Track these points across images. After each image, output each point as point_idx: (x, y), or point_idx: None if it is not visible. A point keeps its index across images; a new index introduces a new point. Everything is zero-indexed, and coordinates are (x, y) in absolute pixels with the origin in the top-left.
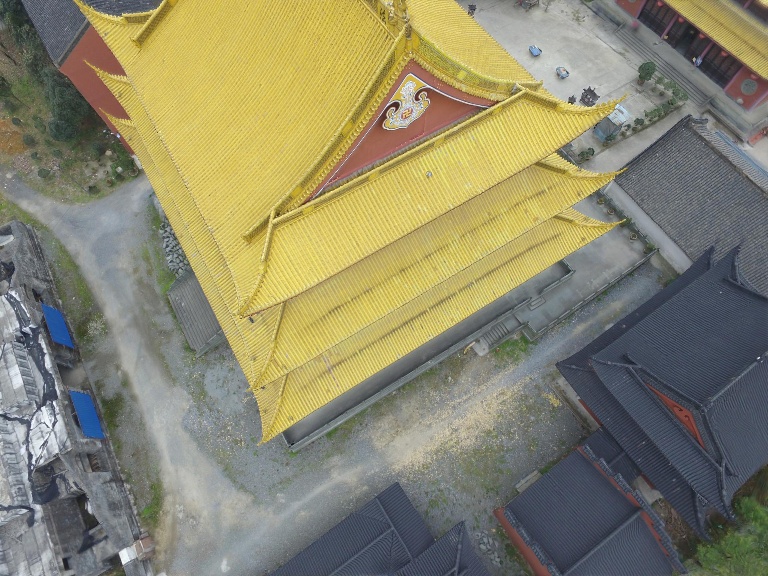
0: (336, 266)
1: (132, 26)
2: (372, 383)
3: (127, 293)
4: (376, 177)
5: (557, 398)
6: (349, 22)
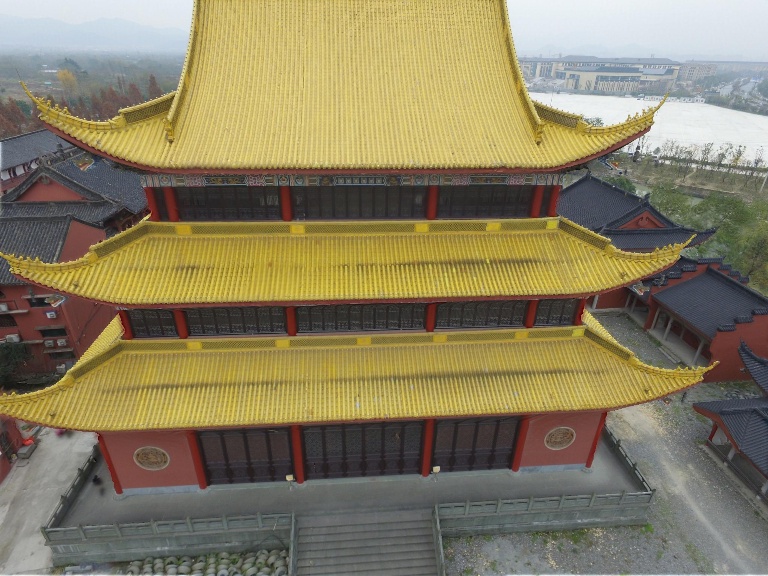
0: None
1: (132, 128)
2: None
3: None
4: None
5: None
6: None
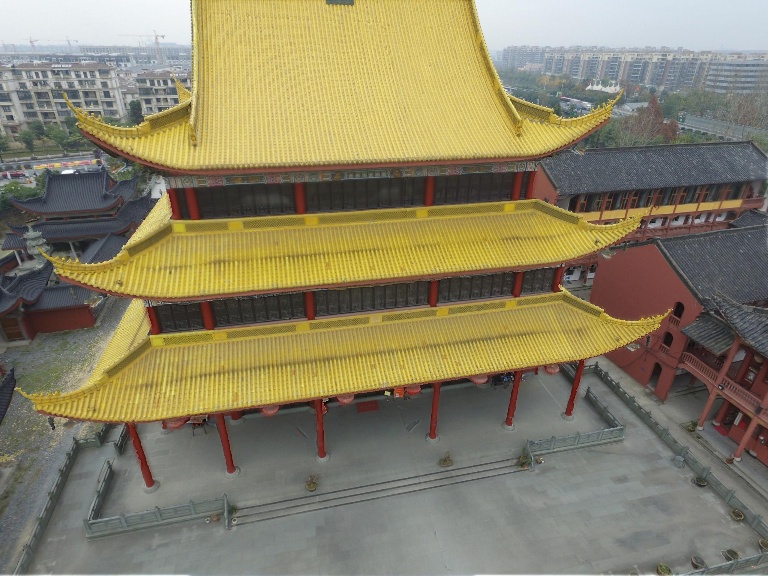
0: None
1: None
2: None
3: None
4: None
5: None
6: None
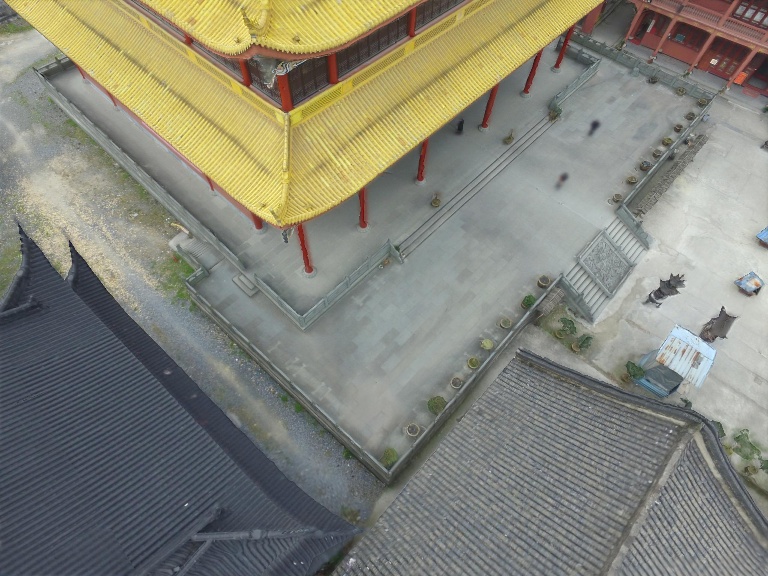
0: None
1: None
2: (113, 126)
3: None
4: None
5: None
6: None
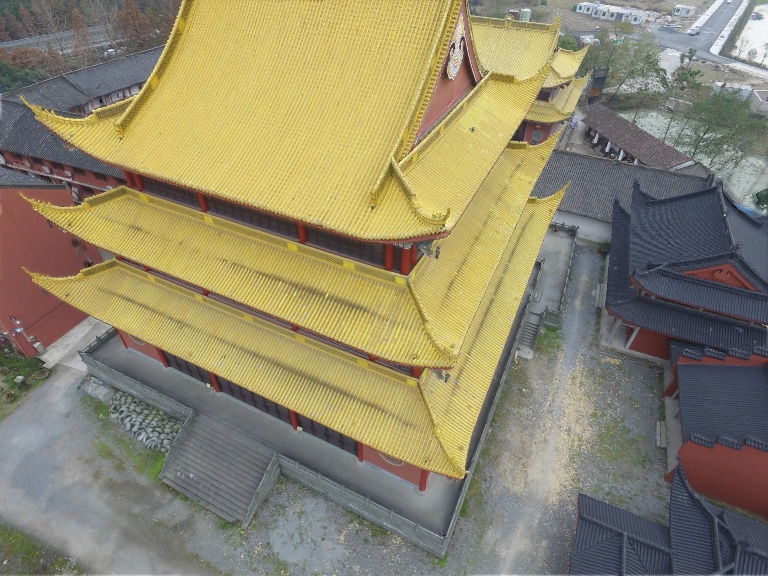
0: (461, 202)
1: (103, 122)
2: None
3: (97, 508)
4: (442, 133)
5: (613, 358)
6: (387, 3)
